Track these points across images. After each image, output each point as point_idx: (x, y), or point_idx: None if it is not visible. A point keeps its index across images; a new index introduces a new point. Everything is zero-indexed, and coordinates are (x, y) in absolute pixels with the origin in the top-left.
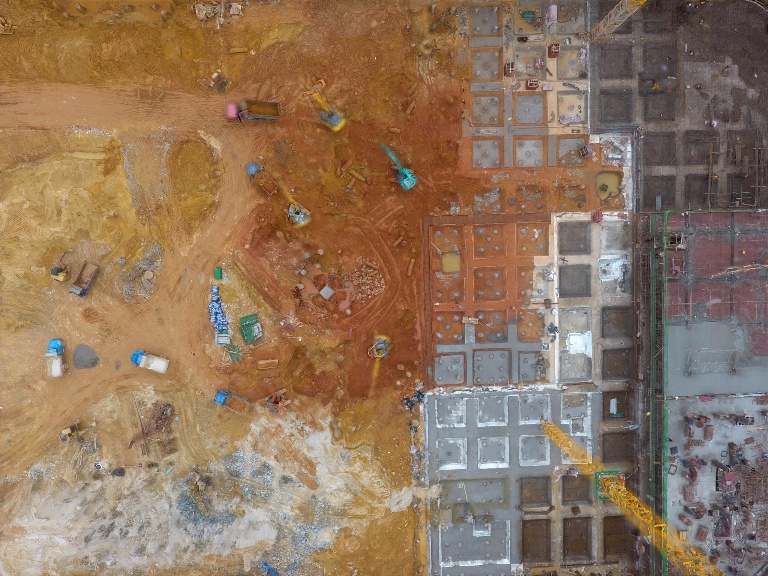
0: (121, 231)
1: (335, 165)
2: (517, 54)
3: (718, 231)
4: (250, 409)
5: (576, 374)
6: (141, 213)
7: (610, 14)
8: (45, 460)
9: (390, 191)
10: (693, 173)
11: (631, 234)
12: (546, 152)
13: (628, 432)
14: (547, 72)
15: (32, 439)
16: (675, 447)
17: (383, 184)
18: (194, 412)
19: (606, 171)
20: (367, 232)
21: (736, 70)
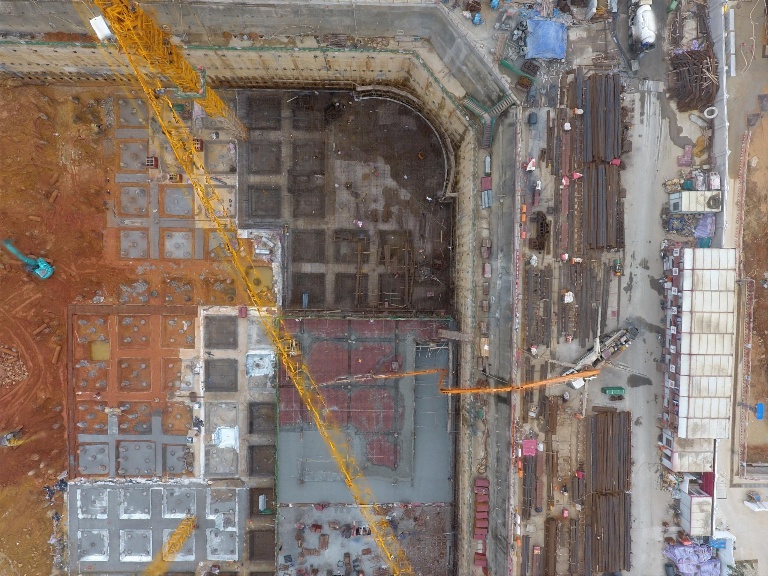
0: None
1: None
2: (166, 146)
3: (334, 338)
4: None
5: (225, 468)
6: None
7: None
8: None
9: None
10: (343, 271)
11: None
12: (194, 245)
13: None
14: (194, 166)
15: None
16: (289, 555)
17: (22, 272)
18: None
19: None
20: (1, 320)
21: (388, 170)
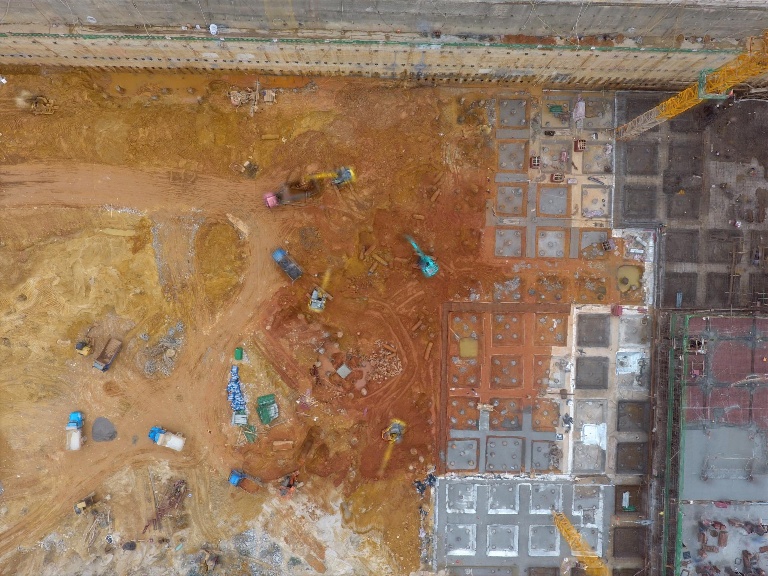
0: (146, 307)
1: (359, 249)
2: (543, 146)
3: (739, 337)
4: (263, 489)
5: (589, 465)
6: (167, 291)
7: (638, 119)
8: (58, 531)
9: (412, 277)
10: (715, 271)
11: (650, 328)
12: (568, 244)
13: (640, 527)
14: (572, 166)
15: (47, 509)
16: (688, 552)
17: (405, 269)
18: (207, 490)
19: (627, 265)
20: (387, 316)
21: (762, 171)
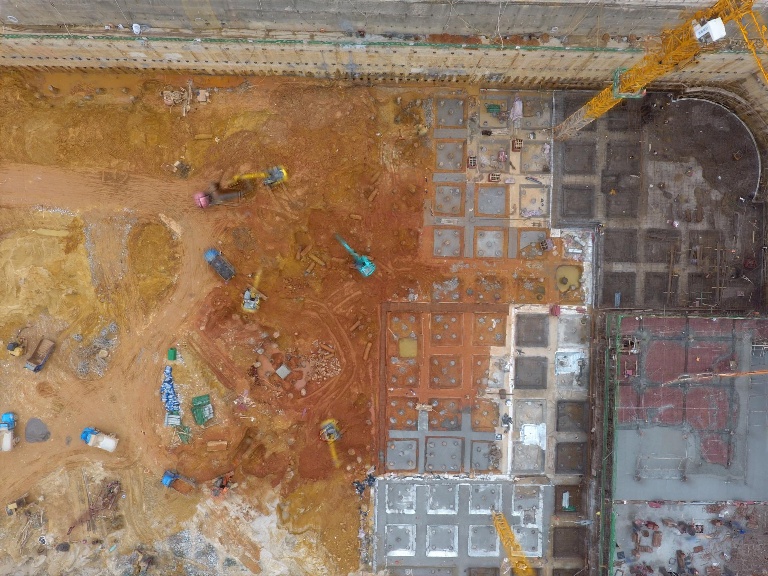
0: (80, 308)
1: (295, 250)
2: (481, 146)
3: (672, 337)
4: (197, 490)
5: (529, 465)
6: (100, 291)
7: (570, 118)
8: None
9: (348, 277)
10: (654, 271)
11: (589, 328)
12: (507, 244)
13: (580, 527)
14: (510, 165)
15: None
16: (622, 552)
17: (342, 269)
18: (141, 491)
19: (566, 265)
20: (324, 317)
21: (700, 171)
